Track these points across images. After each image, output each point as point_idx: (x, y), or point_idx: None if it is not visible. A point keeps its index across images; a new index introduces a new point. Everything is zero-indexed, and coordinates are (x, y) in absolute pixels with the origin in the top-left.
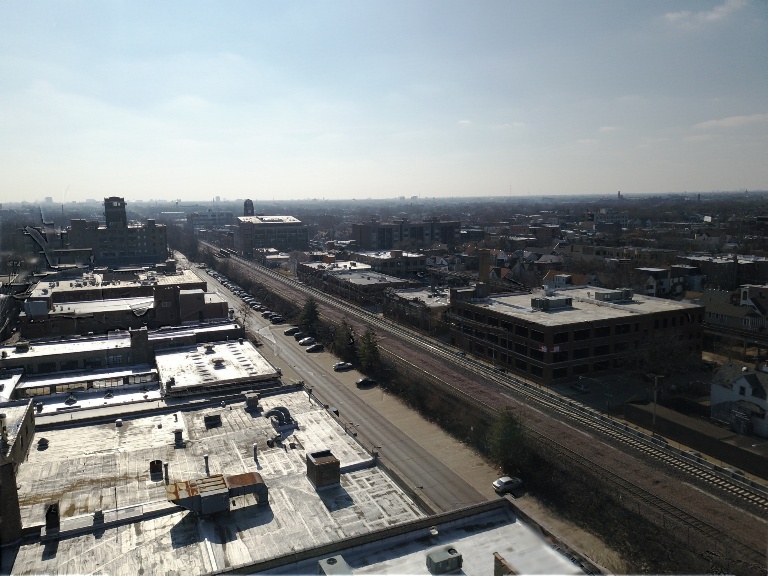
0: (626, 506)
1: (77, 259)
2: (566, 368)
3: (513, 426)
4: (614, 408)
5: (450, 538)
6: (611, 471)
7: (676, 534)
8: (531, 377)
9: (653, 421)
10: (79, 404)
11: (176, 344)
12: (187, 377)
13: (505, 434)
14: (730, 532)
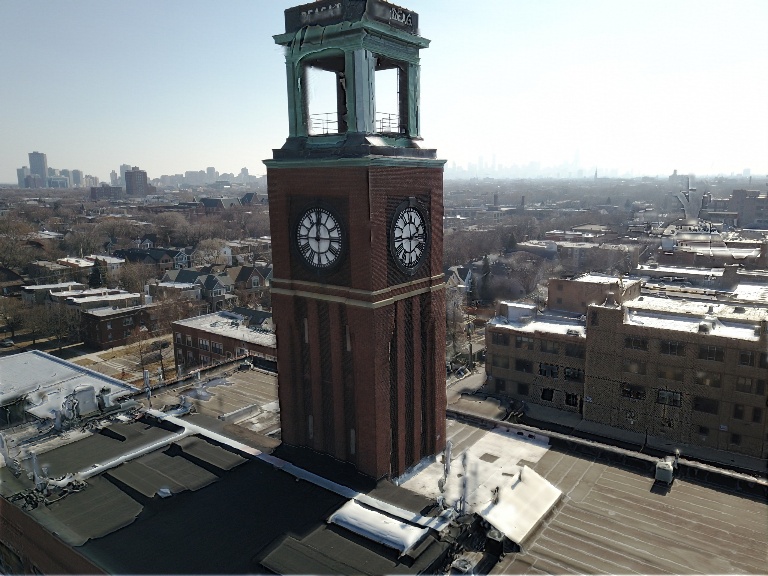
0: None
1: (714, 218)
2: None
3: None
4: None
5: None
6: None
7: None
8: None
9: None
10: (666, 287)
11: (759, 280)
12: (749, 296)
13: None
14: None
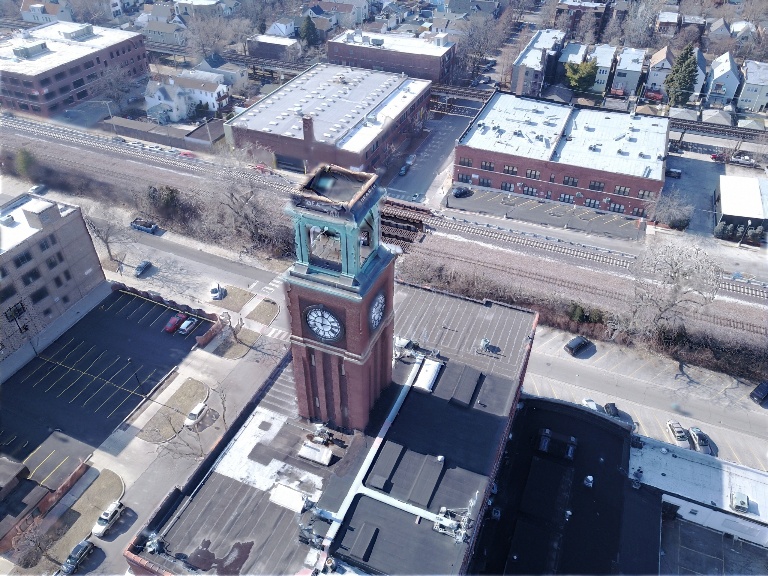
0: (99, 180)
1: None
2: (55, 106)
3: (29, 156)
4: (90, 127)
5: (7, 213)
6: (91, 165)
7: (121, 185)
8: (34, 118)
9: (111, 130)
10: None
11: None
12: None
13: (26, 162)
14: (142, 177)
